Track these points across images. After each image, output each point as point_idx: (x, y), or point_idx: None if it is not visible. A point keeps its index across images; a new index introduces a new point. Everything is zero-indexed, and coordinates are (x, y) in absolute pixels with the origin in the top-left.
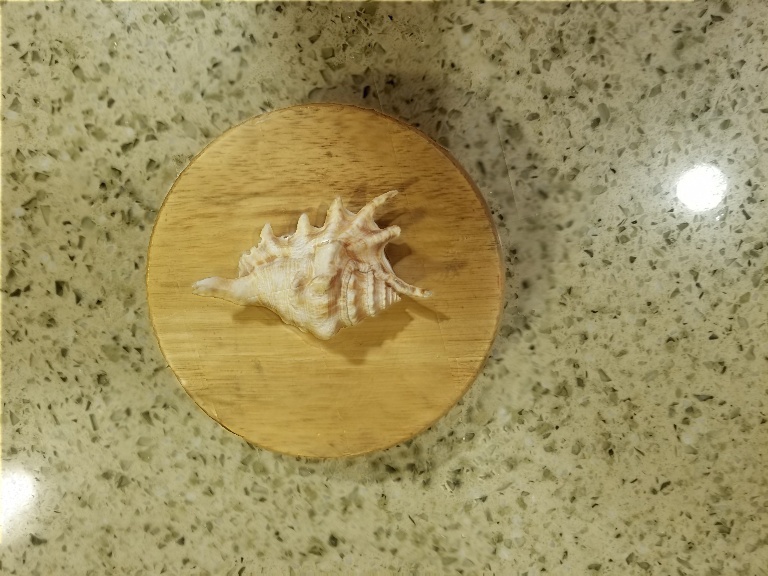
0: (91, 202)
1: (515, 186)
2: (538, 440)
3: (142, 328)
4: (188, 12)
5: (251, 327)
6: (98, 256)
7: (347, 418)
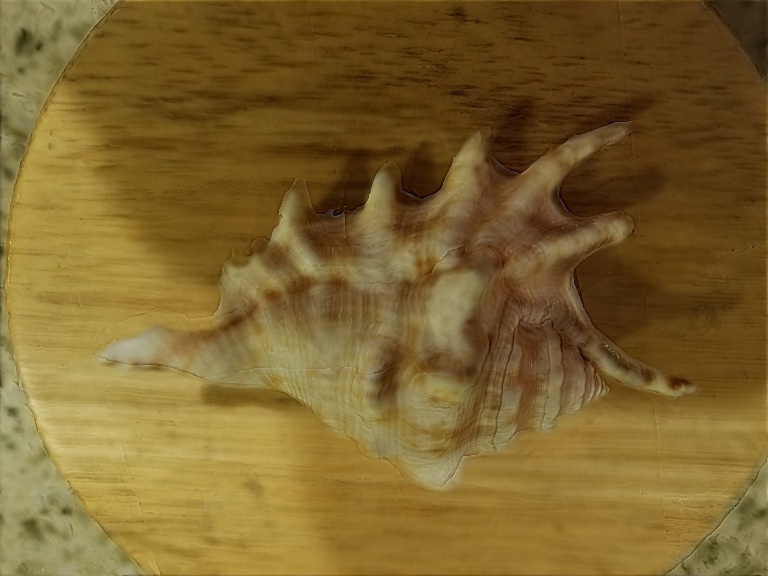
0: None
1: None
2: None
3: None
4: None
5: (242, 405)
6: None
7: None
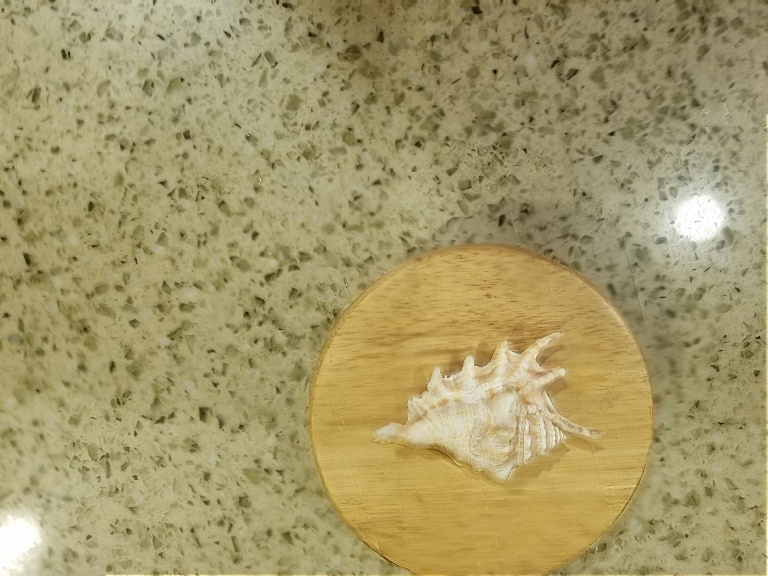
0: (235, 331)
1: (644, 306)
2: (669, 548)
3: (283, 450)
4: (331, 149)
5: (413, 462)
6: (241, 382)
7: (505, 547)
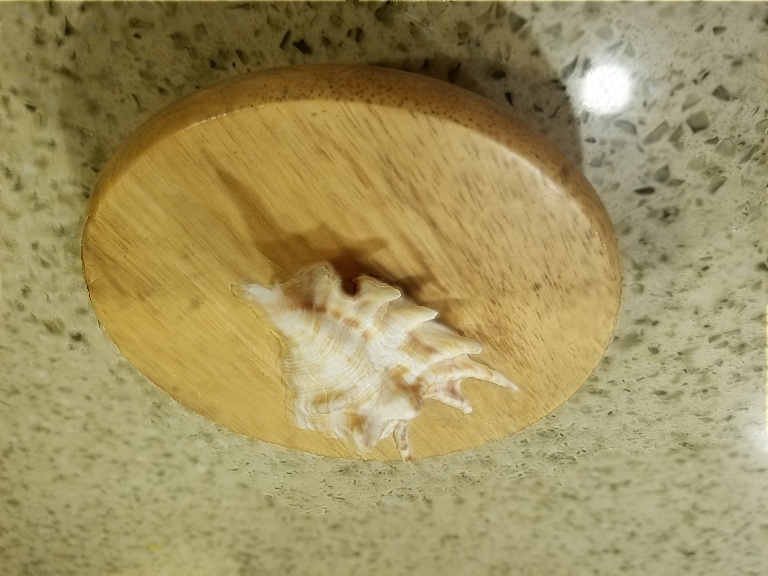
0: None
1: None
2: None
3: (106, 15)
4: None
5: (239, 283)
6: None
7: (215, 391)
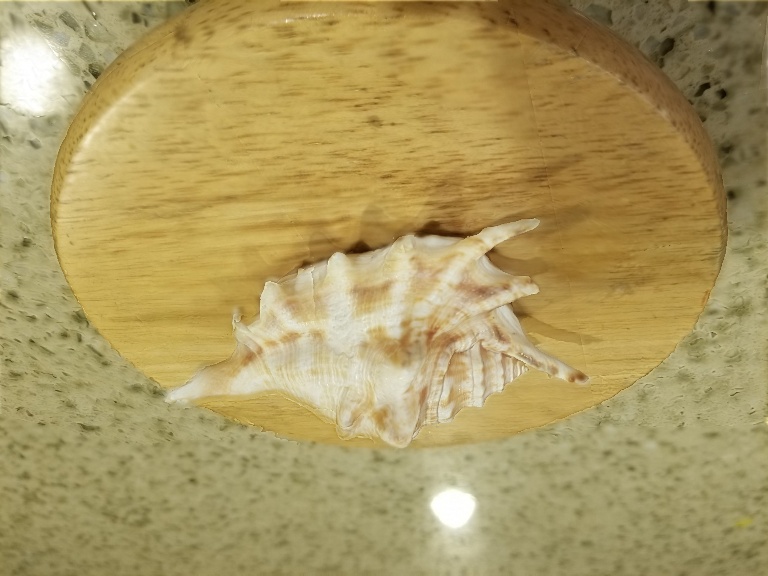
0: None
1: None
2: (682, 346)
3: None
4: None
5: None
6: None
7: None
